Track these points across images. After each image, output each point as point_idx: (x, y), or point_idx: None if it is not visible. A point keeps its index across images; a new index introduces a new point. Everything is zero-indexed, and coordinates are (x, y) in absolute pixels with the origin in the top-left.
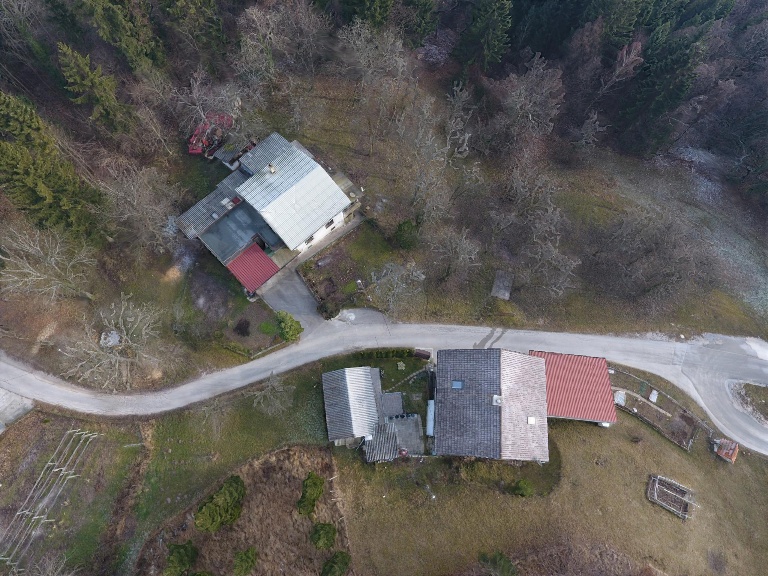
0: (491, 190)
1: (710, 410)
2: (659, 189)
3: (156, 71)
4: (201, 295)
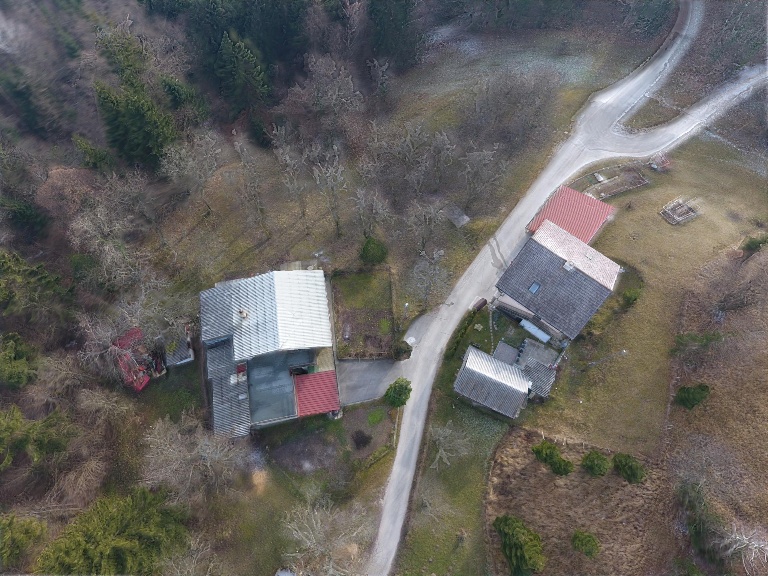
0: None
1: (625, 153)
2: (443, 73)
3: (46, 358)
4: (301, 461)
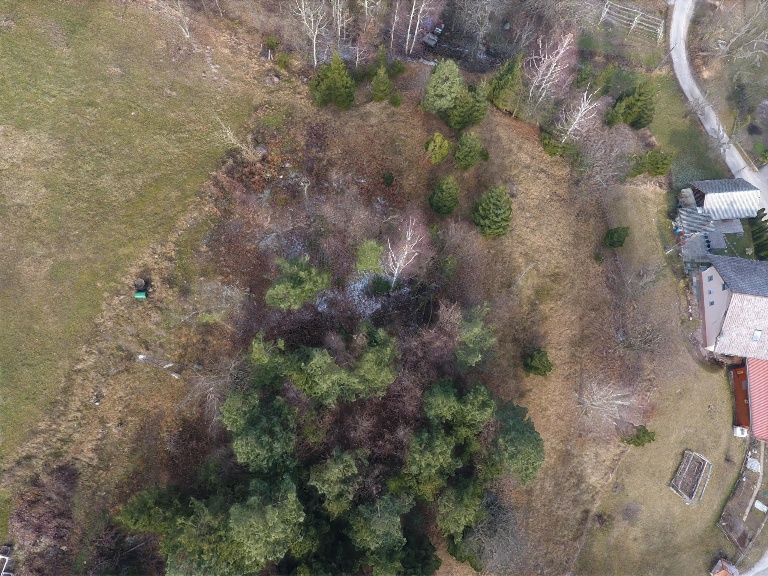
0: None
1: None
2: None
3: None
4: None
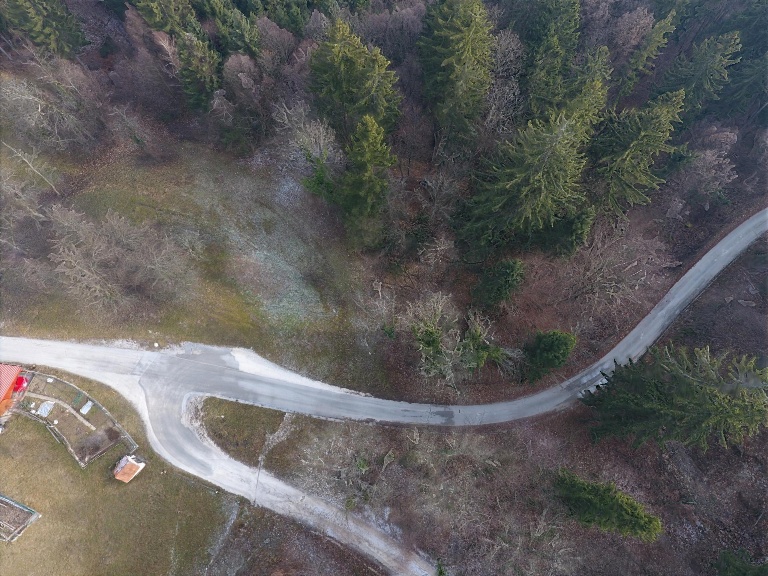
0: (55, 186)
1: (151, 424)
2: (241, 189)
3: None
4: None
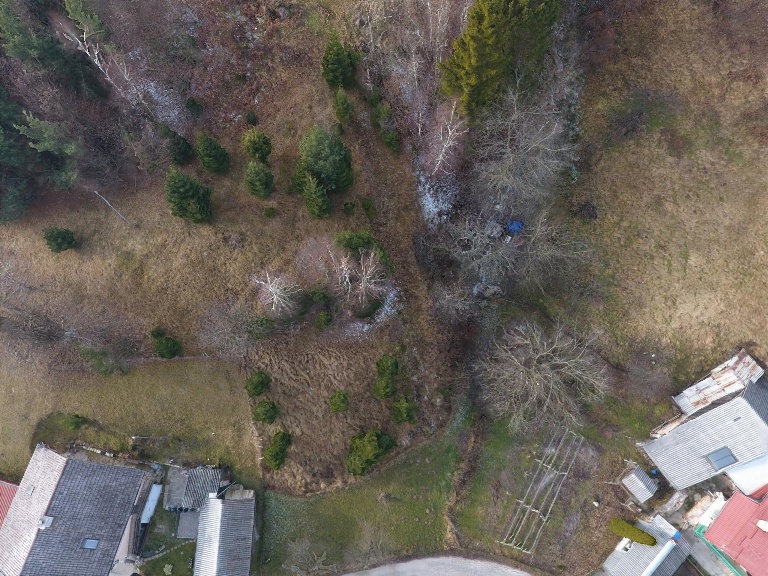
0: None
1: None
2: None
3: None
4: None
